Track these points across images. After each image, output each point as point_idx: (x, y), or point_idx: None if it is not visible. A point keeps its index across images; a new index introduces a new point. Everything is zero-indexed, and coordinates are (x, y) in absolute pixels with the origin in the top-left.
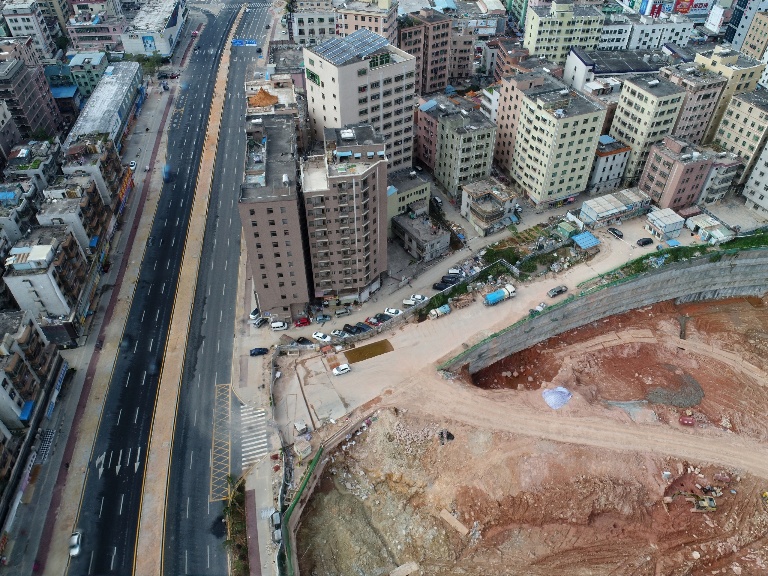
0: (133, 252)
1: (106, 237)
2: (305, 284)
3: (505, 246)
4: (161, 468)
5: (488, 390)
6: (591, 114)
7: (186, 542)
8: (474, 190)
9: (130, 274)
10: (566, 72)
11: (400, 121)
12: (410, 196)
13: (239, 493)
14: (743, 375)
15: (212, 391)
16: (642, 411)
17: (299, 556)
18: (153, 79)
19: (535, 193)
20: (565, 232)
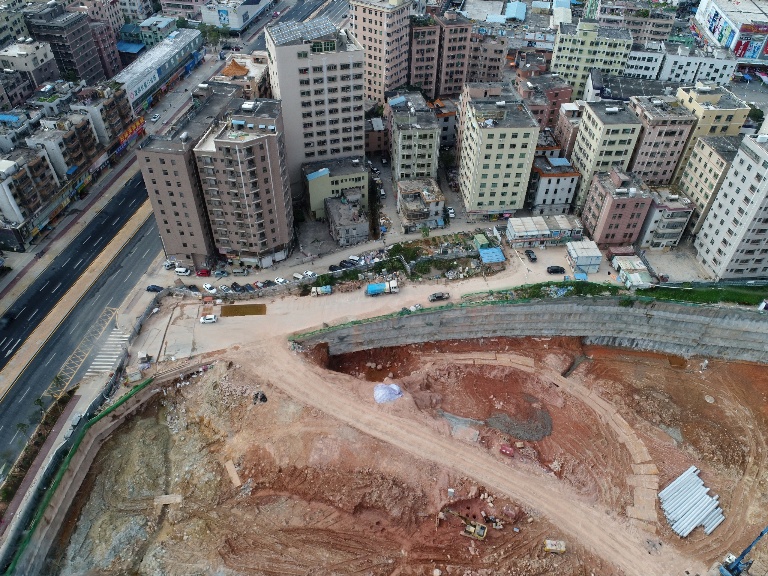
0: (111, 188)
1: (90, 170)
2: (202, 237)
3: None
4: (24, 359)
5: None
6: (521, 129)
7: (6, 420)
8: (406, 187)
9: (98, 204)
10: (584, 94)
11: (349, 109)
12: (345, 181)
13: (67, 395)
14: (607, 427)
15: (100, 311)
16: (466, 429)
17: (95, 461)
18: (218, 49)
19: (466, 201)
20: (478, 244)
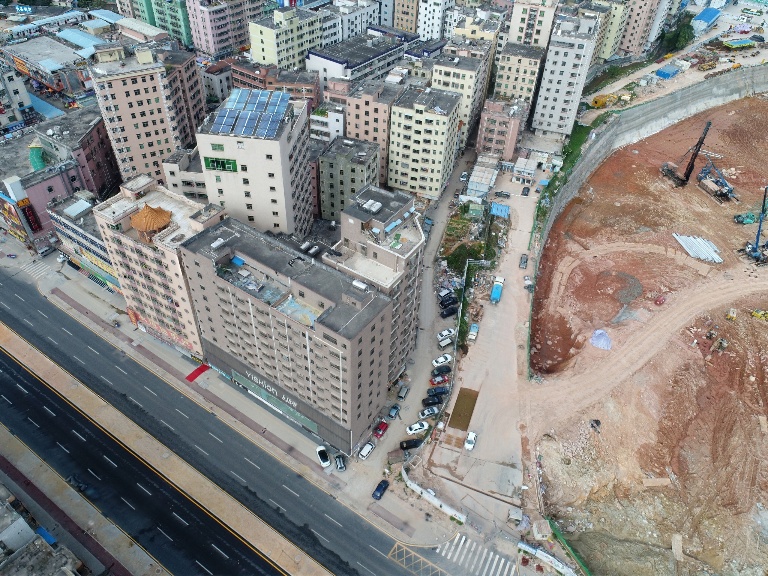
0: (72, 513)
1: None
2: (386, 387)
3: (450, 248)
4: None
5: (568, 369)
6: (457, 102)
7: None
8: None
9: (110, 540)
10: None
11: None
12: None
13: None
14: (635, 252)
15: (393, 565)
16: (639, 313)
17: None
18: None
19: (431, 191)
20: (479, 212)
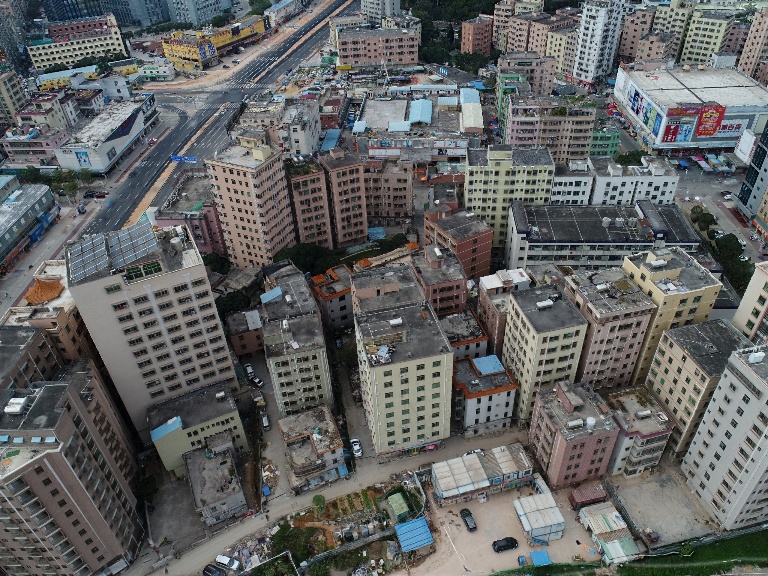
0: None
1: None
2: None
3: (310, 521)
4: None
5: None
6: (427, 359)
7: None
8: (289, 429)
9: None
10: (508, 229)
11: (199, 332)
12: (207, 428)
13: None
14: None
15: None
16: None
17: None
18: (79, 198)
19: (373, 439)
20: (394, 512)
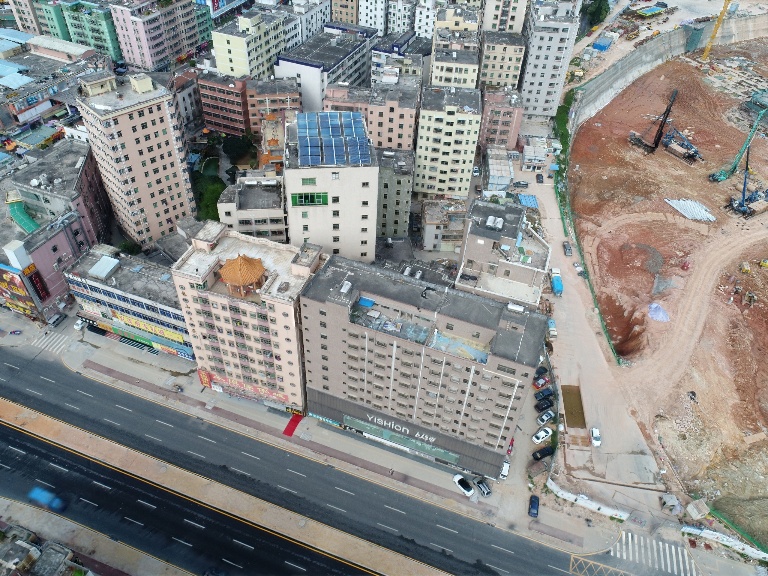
0: None
1: None
2: None
3: None
4: None
5: (645, 347)
6: None
7: None
8: (438, 219)
9: None
10: None
11: None
12: None
13: None
14: (641, 222)
15: None
16: (674, 280)
17: None
18: None
19: (460, 191)
20: None
